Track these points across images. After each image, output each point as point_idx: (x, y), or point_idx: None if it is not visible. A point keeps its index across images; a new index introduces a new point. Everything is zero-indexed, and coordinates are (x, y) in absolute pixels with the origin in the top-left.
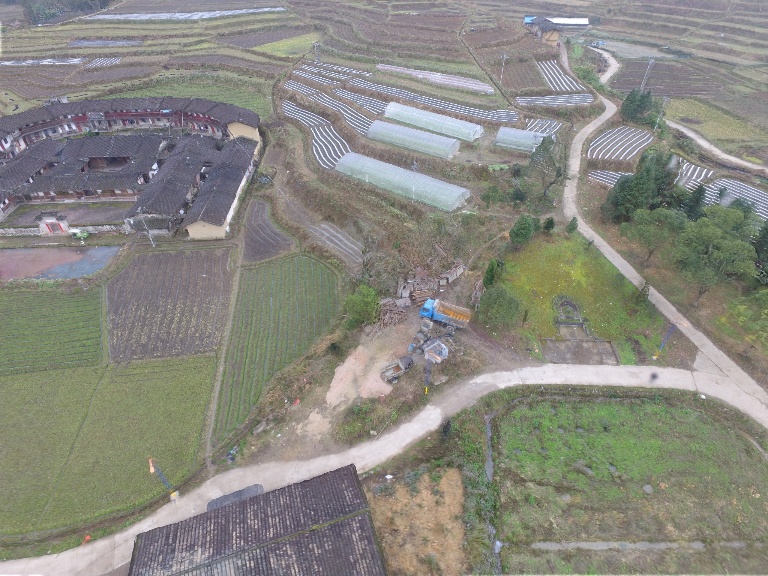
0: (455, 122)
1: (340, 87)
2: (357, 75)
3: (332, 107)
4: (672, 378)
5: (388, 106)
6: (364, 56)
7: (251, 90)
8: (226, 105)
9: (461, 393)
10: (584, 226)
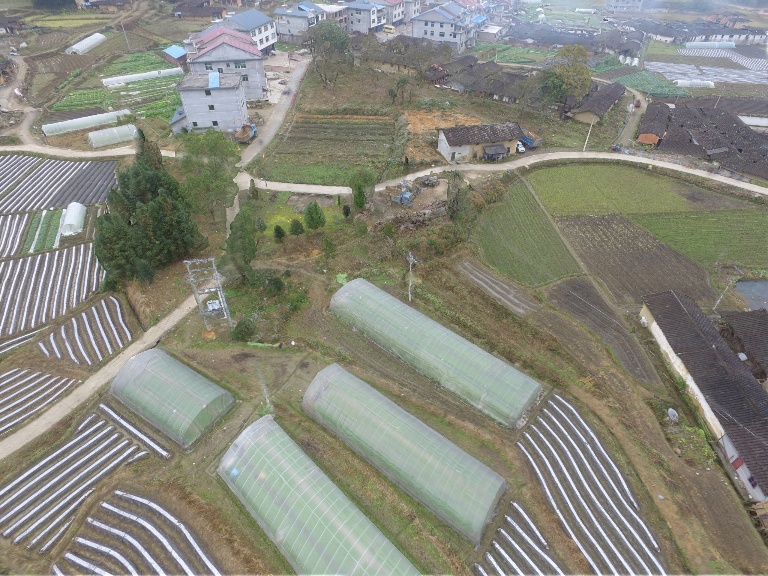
0: (286, 464)
1: None
2: None
3: None
4: (269, 185)
5: None
6: None
7: None
8: None
9: (393, 184)
10: None
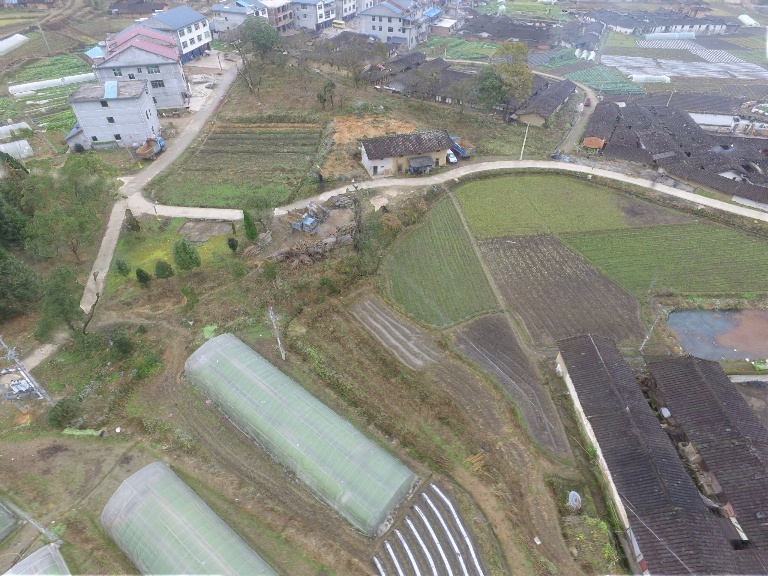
0: None
1: None
2: None
3: None
4: (163, 210)
5: None
6: None
7: None
8: None
9: (304, 205)
10: (86, 302)
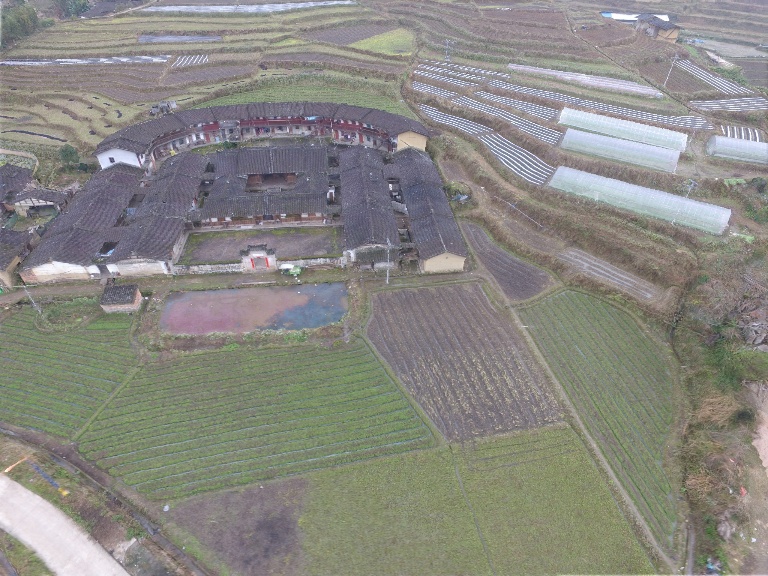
0: (657, 130)
1: (481, 89)
2: (492, 76)
3: (489, 112)
4: None
5: (564, 112)
6: (489, 55)
7: (373, 92)
8: (380, 111)
9: None
10: None
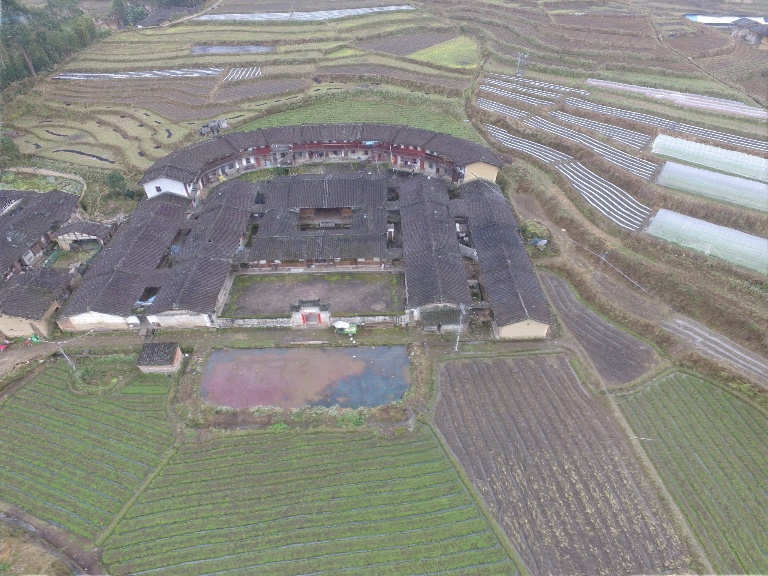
0: None
1: (556, 109)
2: (569, 93)
3: (567, 137)
4: None
5: (659, 139)
6: (565, 68)
7: (435, 110)
8: (445, 136)
9: None
10: None
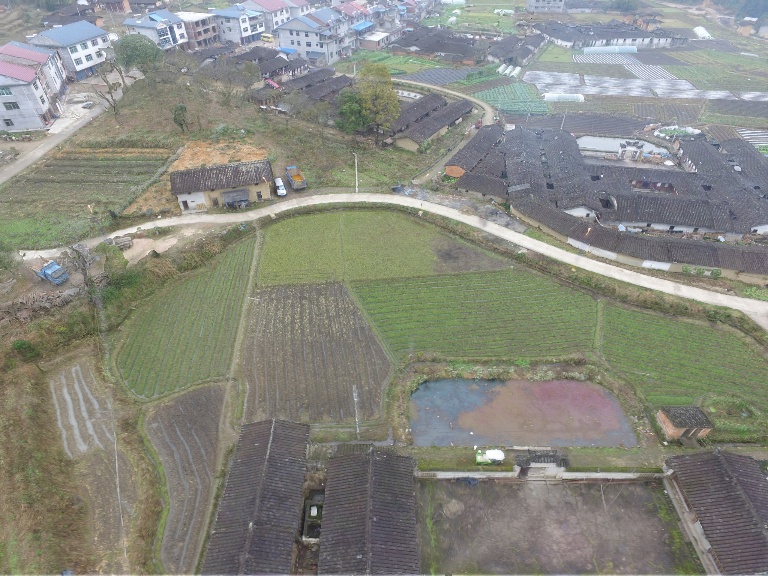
0: None
1: None
2: None
3: None
4: None
5: None
6: None
7: None
8: None
9: None
10: None
